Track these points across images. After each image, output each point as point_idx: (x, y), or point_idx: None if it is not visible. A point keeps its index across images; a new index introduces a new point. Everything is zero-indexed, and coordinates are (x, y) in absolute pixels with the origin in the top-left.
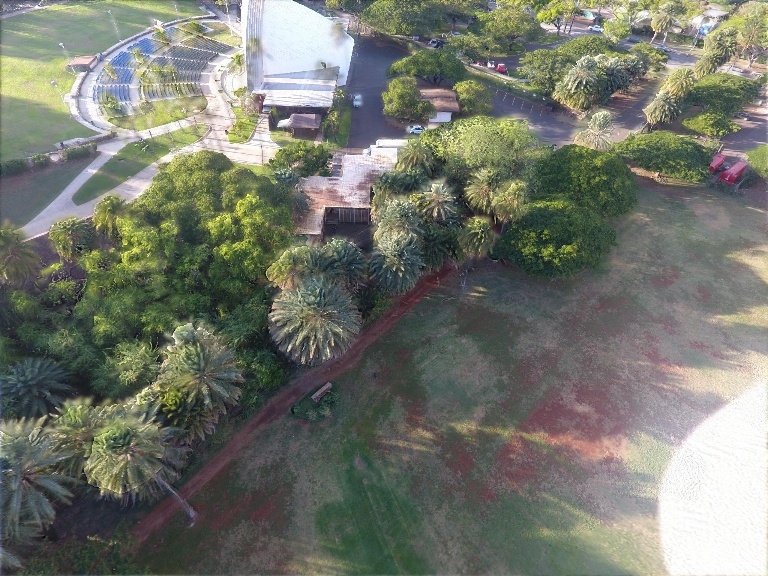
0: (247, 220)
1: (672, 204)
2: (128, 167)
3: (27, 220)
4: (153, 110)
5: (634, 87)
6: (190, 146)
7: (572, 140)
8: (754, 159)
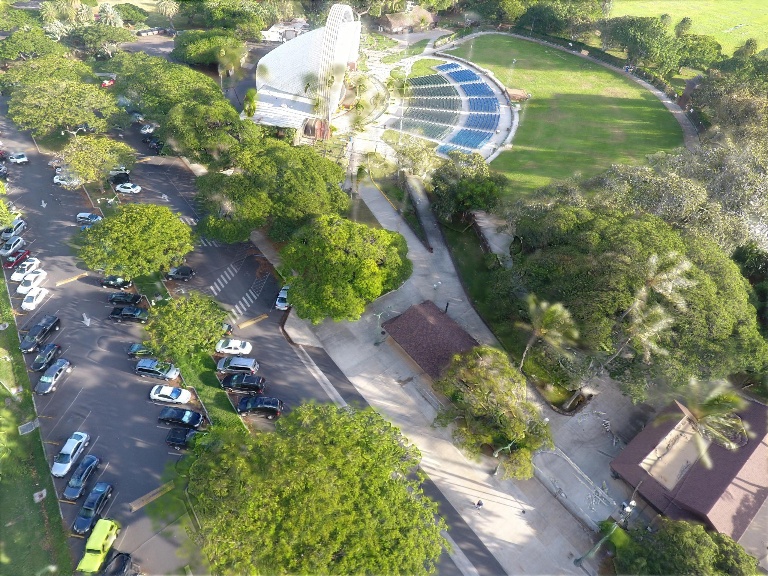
0: None
1: None
2: None
3: (442, 36)
4: None
5: (15, 62)
6: None
7: (146, 42)
8: (89, 4)
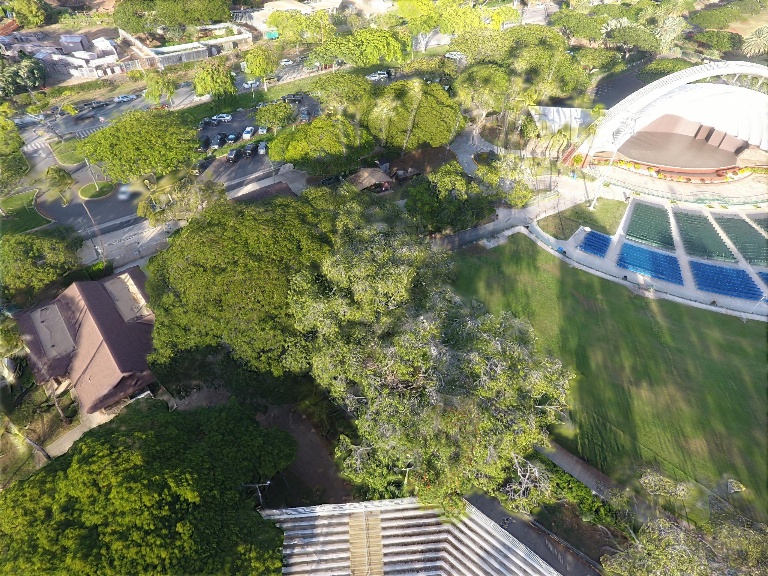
0: None
1: (746, 57)
2: None
3: None
4: None
5: (581, 38)
6: None
7: None
8: (713, 26)
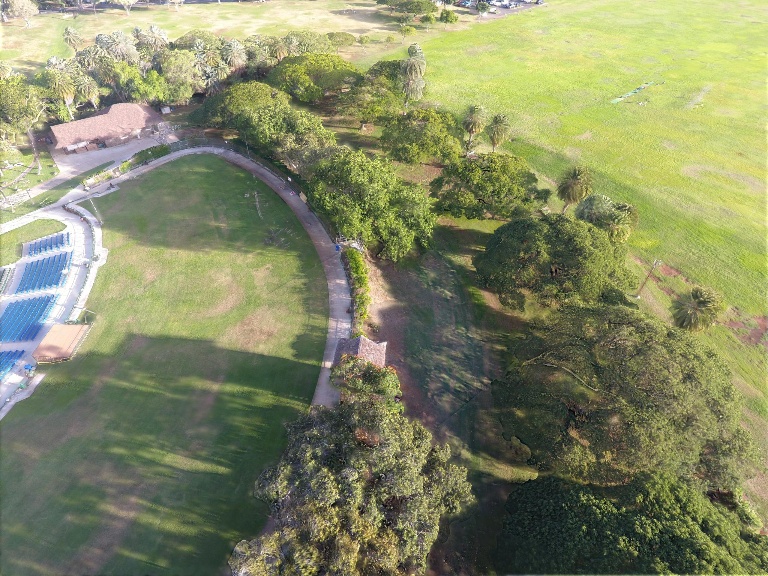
0: (1, 80)
1: None
2: (67, 184)
3: None
4: (3, 137)
5: None
6: (2, 208)
7: None
8: None
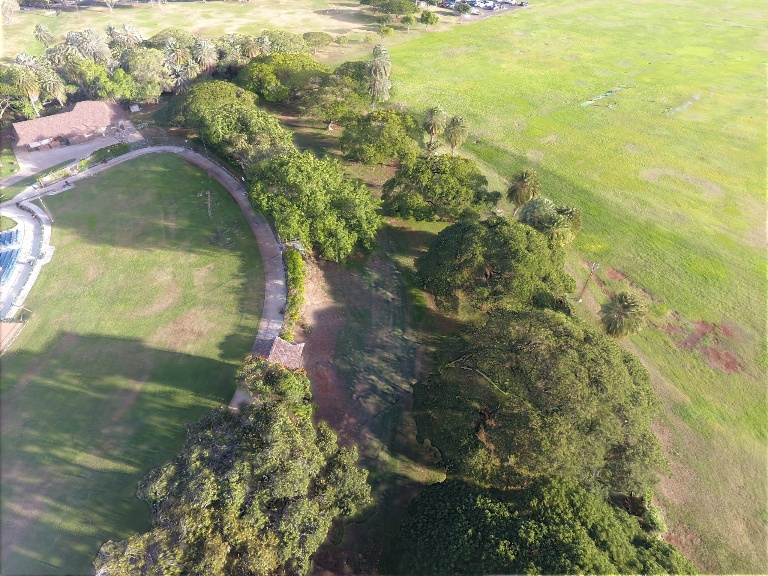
0: None
1: None
2: None
3: None
4: None
5: None
6: None
7: None
8: None
